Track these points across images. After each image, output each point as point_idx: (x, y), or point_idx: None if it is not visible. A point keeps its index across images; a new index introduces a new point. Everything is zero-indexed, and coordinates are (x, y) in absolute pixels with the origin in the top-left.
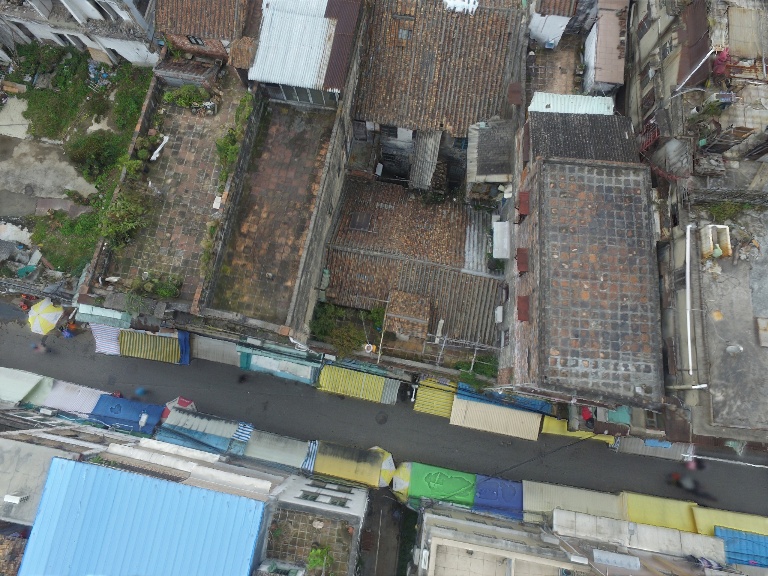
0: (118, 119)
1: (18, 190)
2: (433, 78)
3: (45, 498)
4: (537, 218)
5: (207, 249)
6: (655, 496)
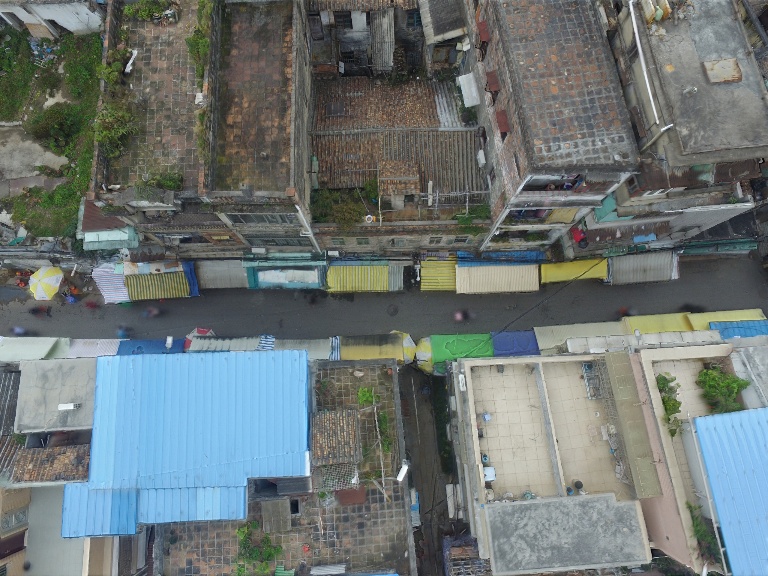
0: (72, 89)
1: None
2: None
3: (99, 394)
4: (498, 36)
5: (200, 134)
6: (653, 314)
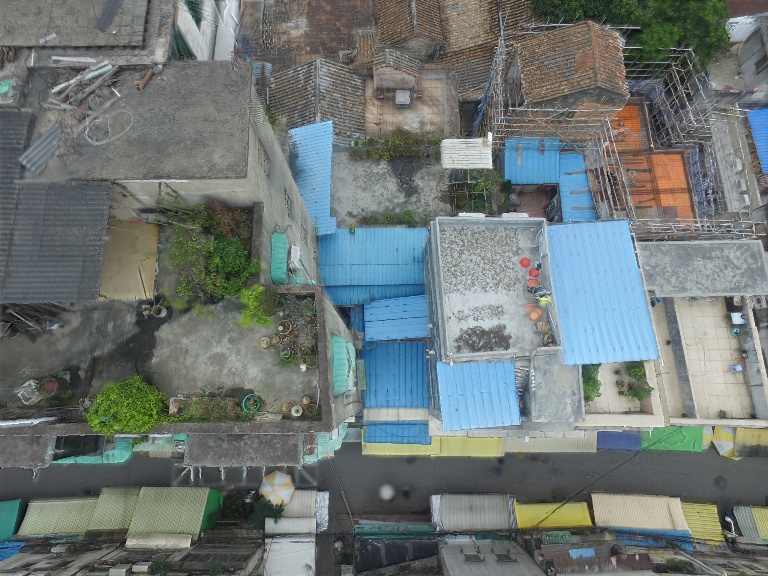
0: None
1: None
2: None
3: None
4: None
5: None
6: None
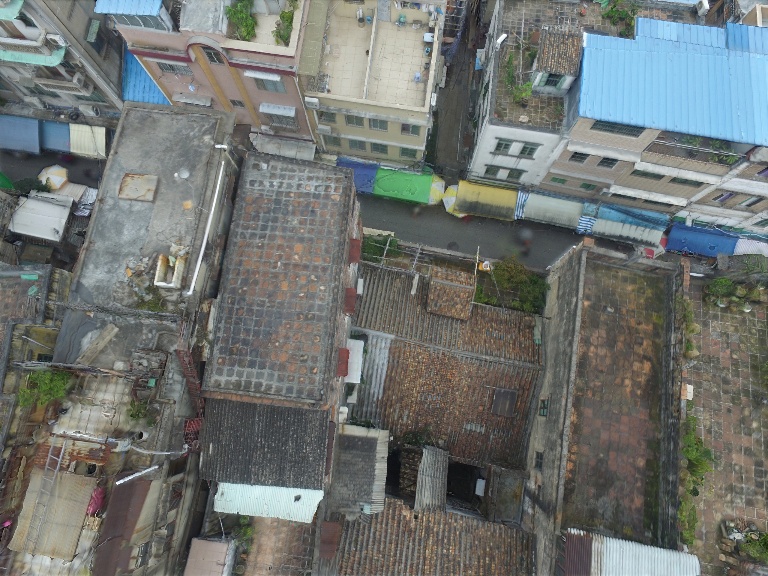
0: None
1: None
2: None
3: None
4: None
5: None
6: None
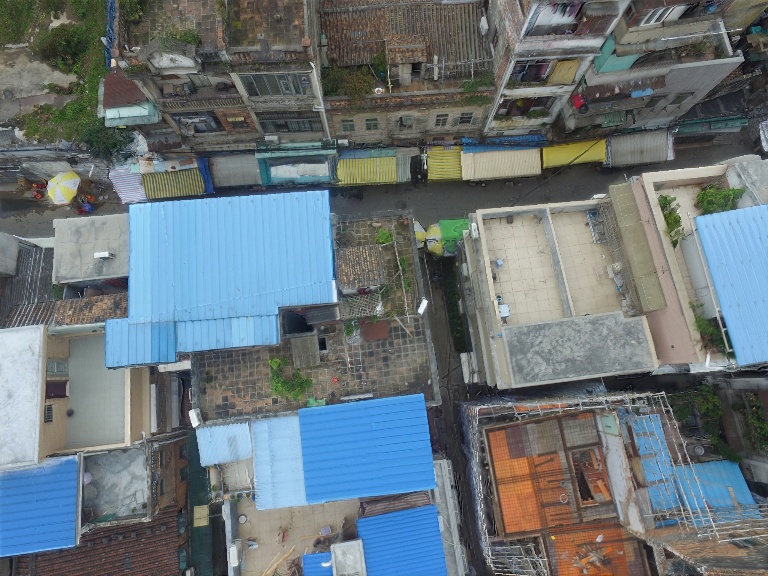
0: (77, 9)
1: None
2: None
3: (133, 239)
4: None
5: None
6: None
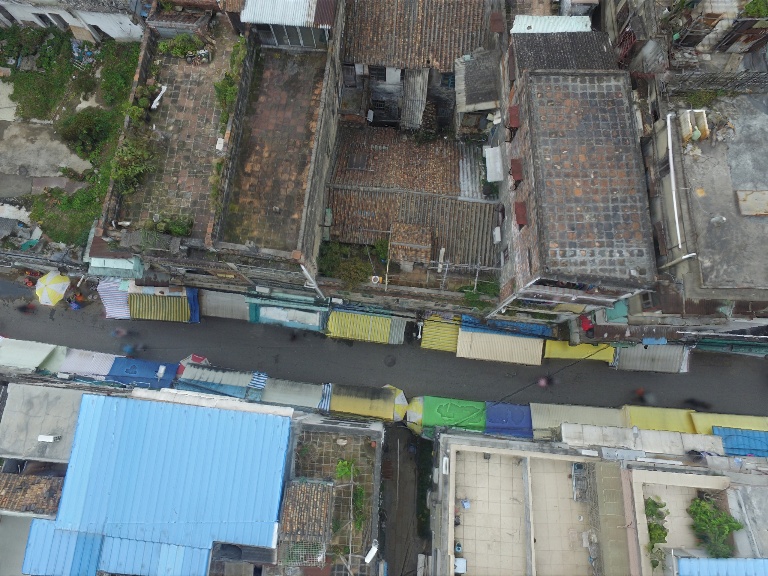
0: (106, 95)
1: (12, 171)
2: (417, 16)
3: (79, 432)
4: (528, 126)
5: (215, 184)
6: (655, 407)
